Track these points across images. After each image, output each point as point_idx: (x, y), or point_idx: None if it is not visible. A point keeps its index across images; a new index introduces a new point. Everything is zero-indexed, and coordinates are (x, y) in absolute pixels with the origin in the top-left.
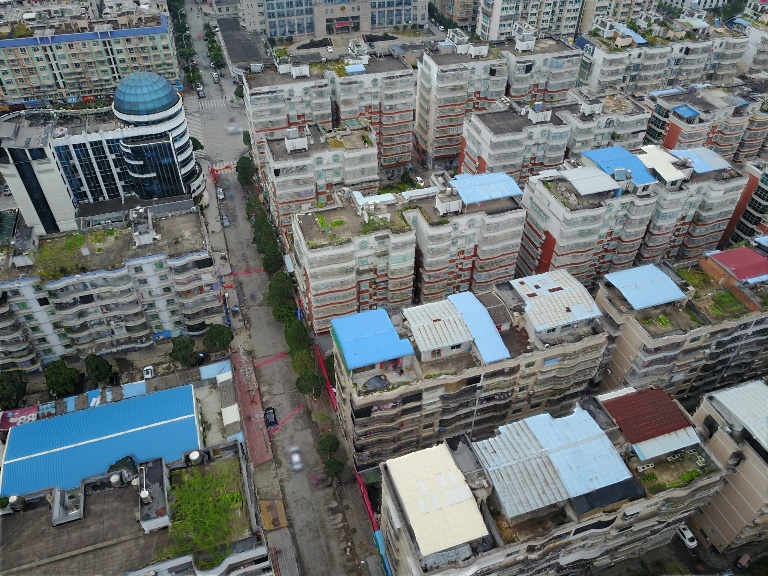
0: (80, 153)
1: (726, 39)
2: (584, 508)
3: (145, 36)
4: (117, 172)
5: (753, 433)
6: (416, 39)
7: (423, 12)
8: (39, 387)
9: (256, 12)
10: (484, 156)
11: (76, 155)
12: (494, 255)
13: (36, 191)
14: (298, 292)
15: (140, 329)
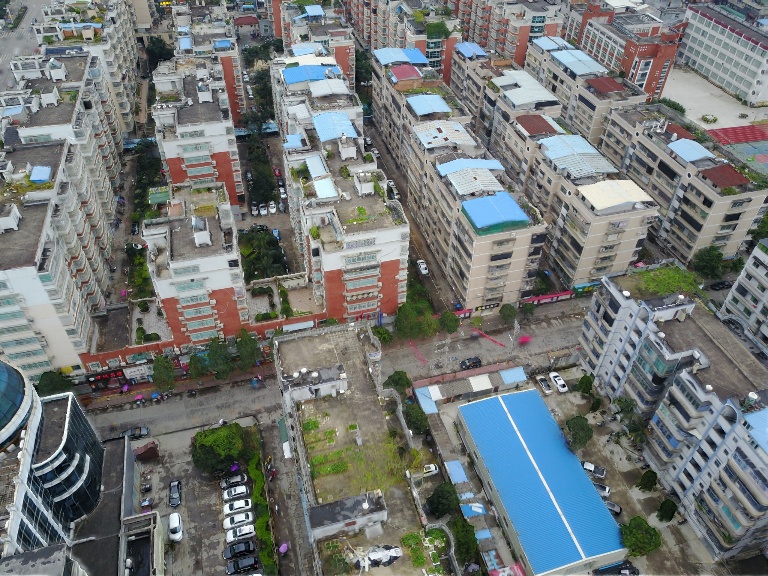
0: (24, 545)
1: (112, 1)
2: (600, 153)
3: None
4: None
5: (542, 100)
6: None
7: None
8: None
9: None
10: (221, 149)
11: None
12: None
13: None
14: None
15: None
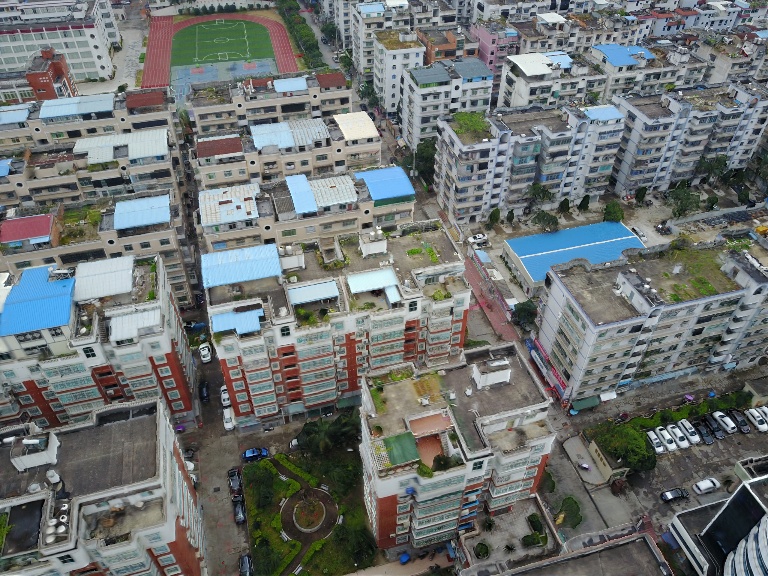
0: None
1: None
2: None
3: None
4: None
5: None
6: None
7: None
8: None
9: None
10: None
11: None
12: None
13: None
14: None
15: None
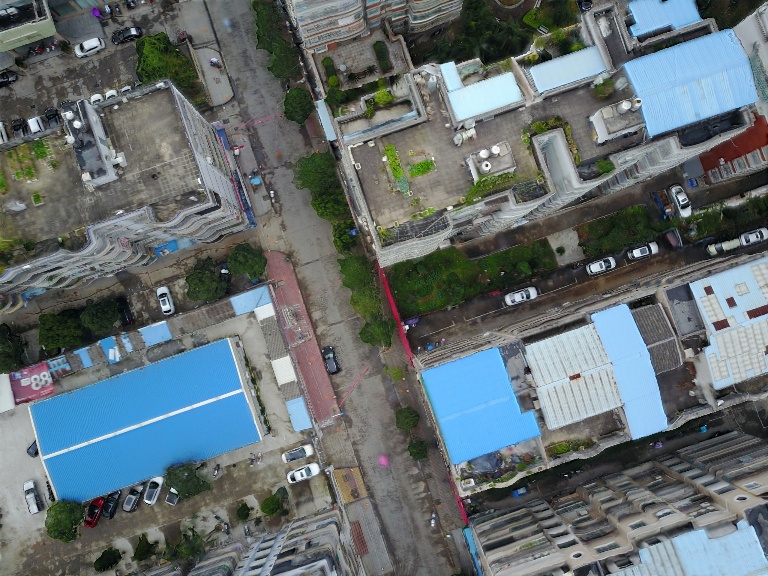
0: None
1: None
2: None
3: None
4: None
5: None
6: None
7: None
8: (34, 319)
9: None
10: None
11: None
12: (663, 167)
13: None
14: None
15: None
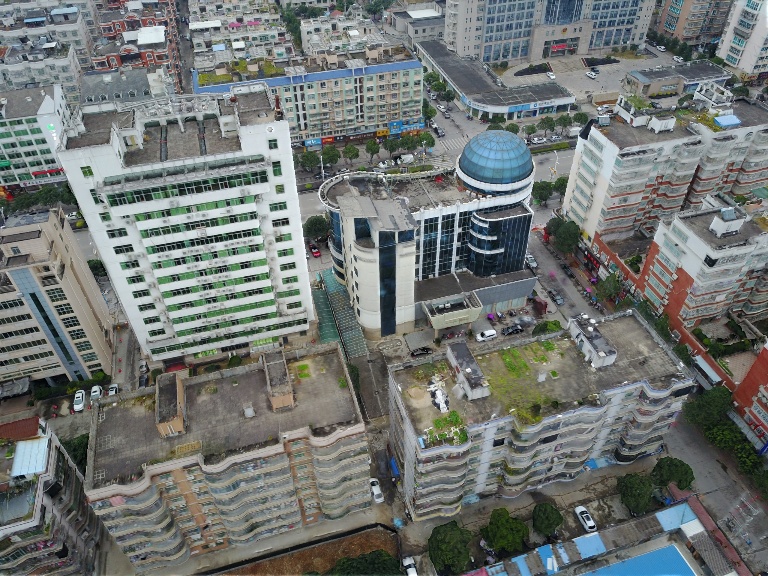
0: (428, 228)
1: None
2: None
3: (399, 72)
4: (457, 247)
5: None
6: (639, 62)
7: (642, 31)
8: None
9: (473, 36)
10: None
11: (423, 230)
12: None
13: (388, 276)
14: (733, 408)
15: (578, 464)
